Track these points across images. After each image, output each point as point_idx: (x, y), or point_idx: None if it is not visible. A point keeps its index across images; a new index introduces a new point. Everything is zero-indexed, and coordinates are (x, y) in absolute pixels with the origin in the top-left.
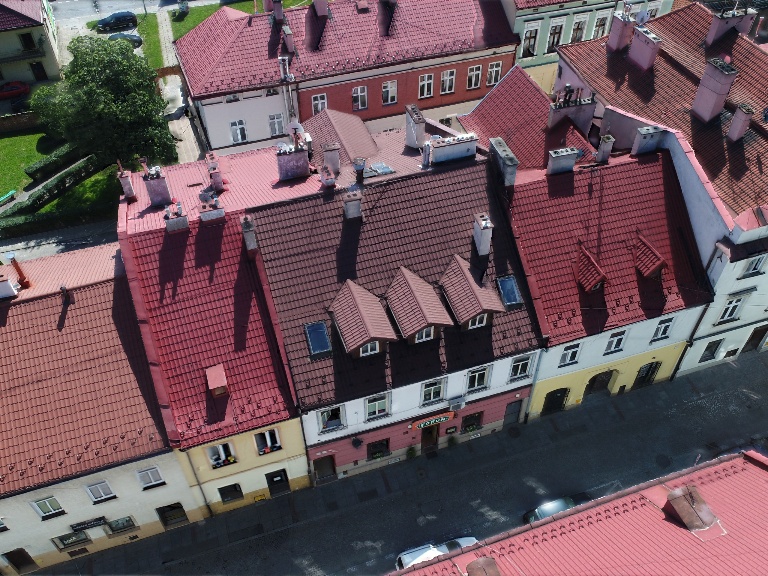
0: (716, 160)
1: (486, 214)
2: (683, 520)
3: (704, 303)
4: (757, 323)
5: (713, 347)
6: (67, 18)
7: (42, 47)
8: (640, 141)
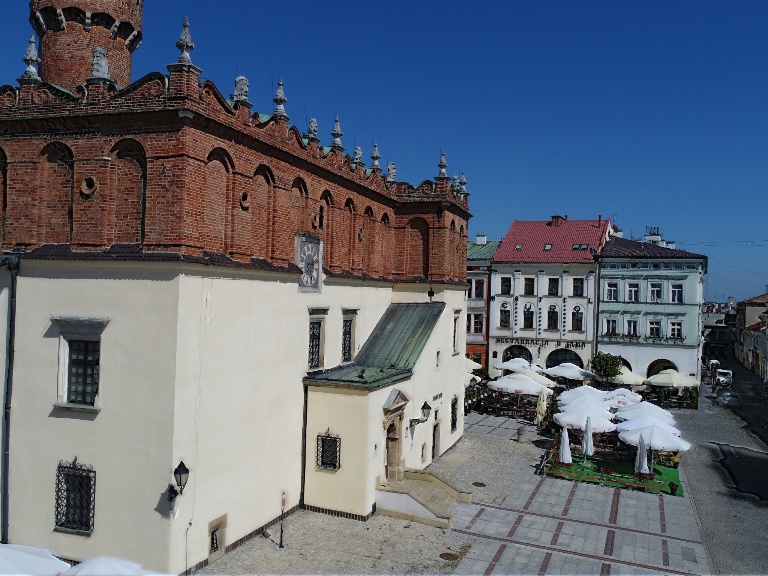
0: None
1: None
2: None
3: None
4: None
5: None
6: None
7: None
8: None
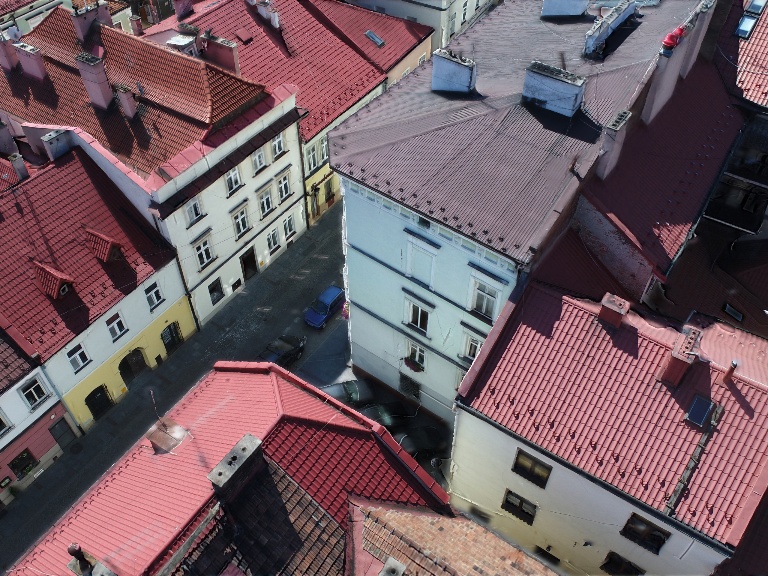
0: (126, 139)
1: None
2: (162, 447)
3: (170, 260)
4: (237, 253)
5: (218, 288)
6: None
7: None
8: (49, 148)
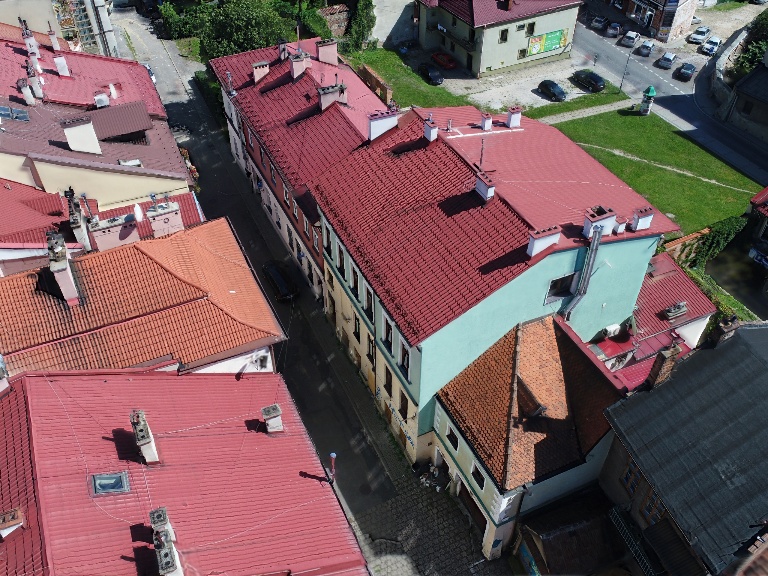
0: None
1: None
2: None
3: None
4: None
5: None
6: (591, 58)
7: (475, 45)
8: None
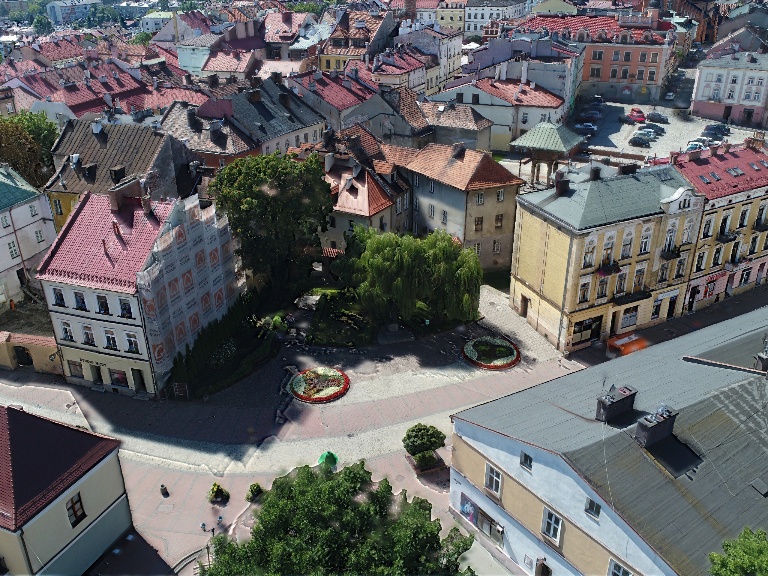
0: None
1: (86, 69)
2: None
3: None
4: None
5: None
6: None
7: None
8: None
